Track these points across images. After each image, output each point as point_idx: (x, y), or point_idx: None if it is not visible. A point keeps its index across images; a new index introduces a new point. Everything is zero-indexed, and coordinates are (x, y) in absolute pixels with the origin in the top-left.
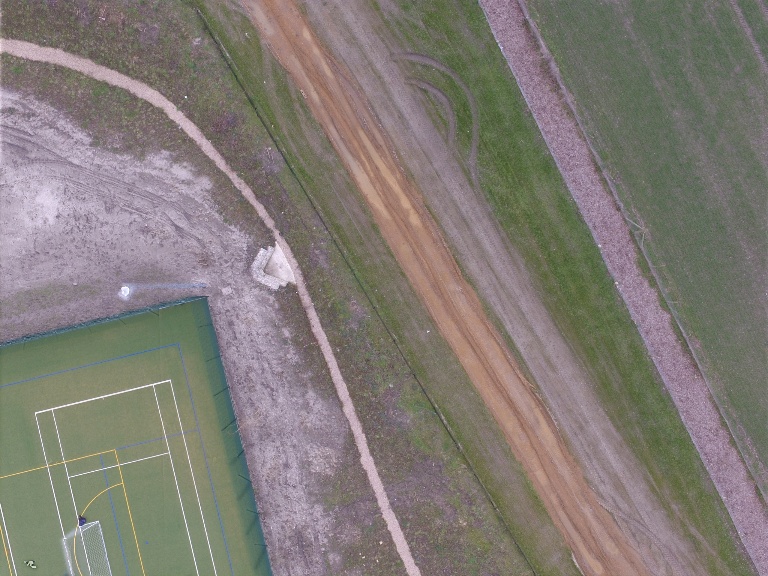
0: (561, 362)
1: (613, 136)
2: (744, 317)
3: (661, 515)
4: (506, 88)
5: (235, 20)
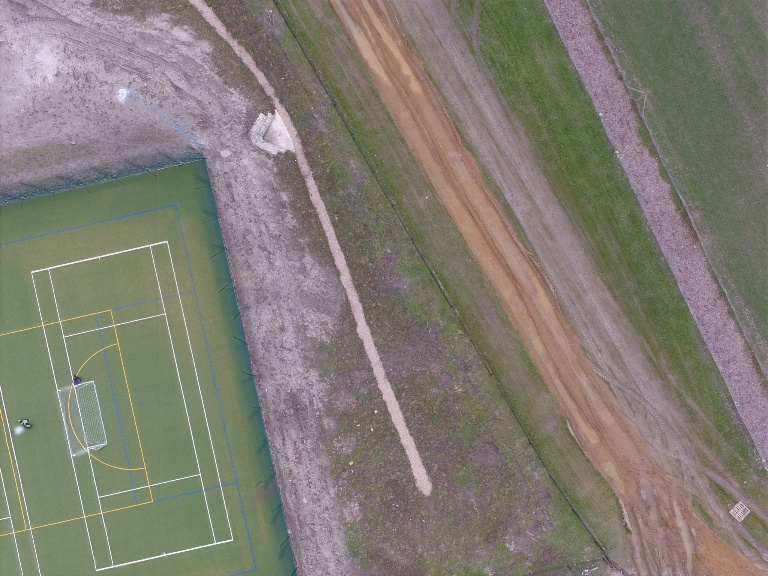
0: (560, 231)
1: (616, 5)
2: (745, 188)
3: (657, 385)
4: None
5: None
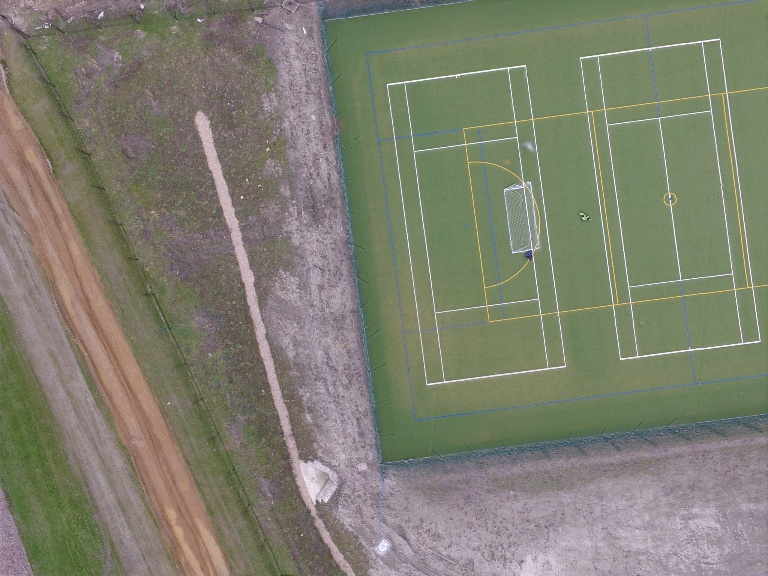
0: (43, 359)
1: None
2: None
3: None
4: None
5: None
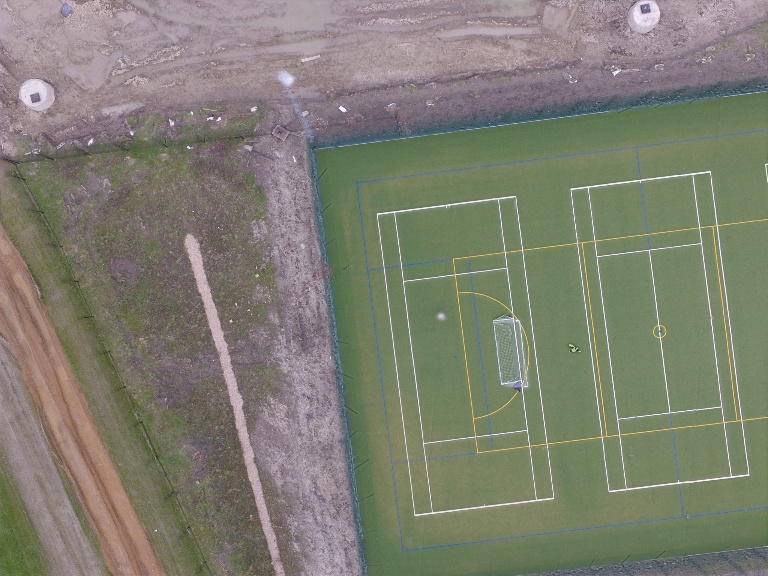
0: (30, 484)
1: None
2: None
3: None
4: None
5: None
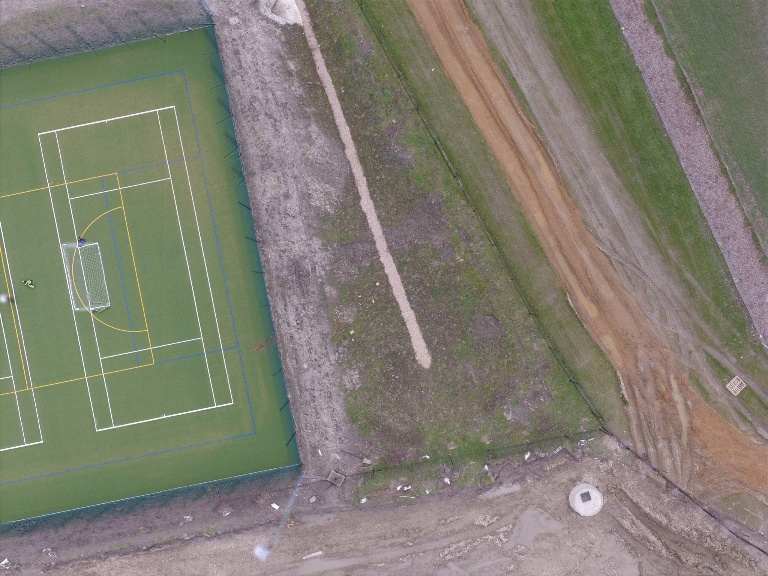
0: (564, 106)
1: None
2: (748, 66)
3: (657, 260)
4: None
5: None
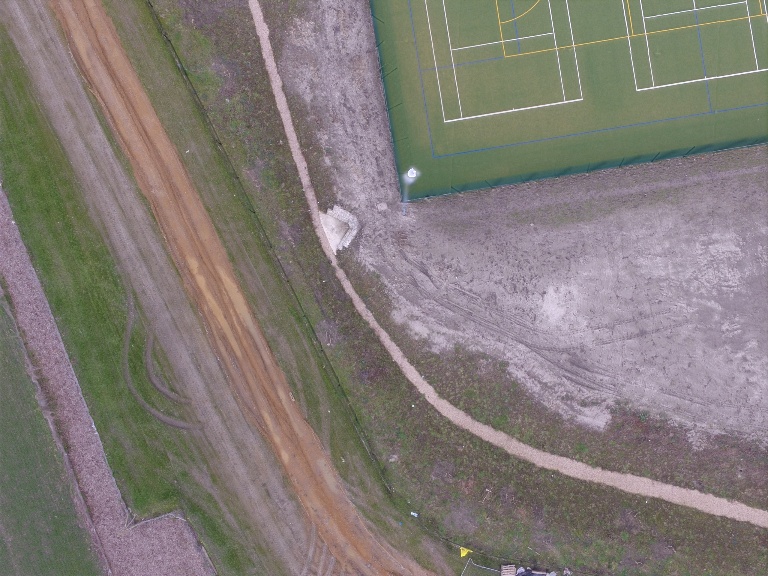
0: (61, 111)
1: None
2: None
3: None
4: (92, 386)
5: (354, 477)
